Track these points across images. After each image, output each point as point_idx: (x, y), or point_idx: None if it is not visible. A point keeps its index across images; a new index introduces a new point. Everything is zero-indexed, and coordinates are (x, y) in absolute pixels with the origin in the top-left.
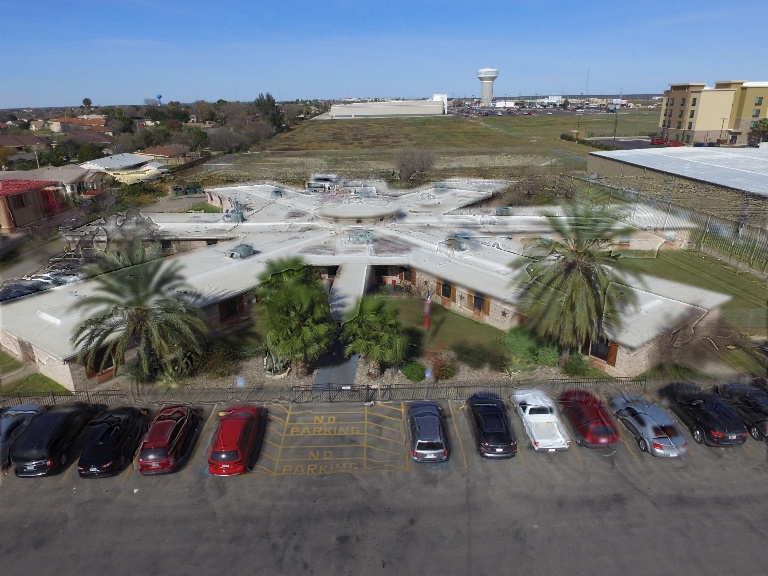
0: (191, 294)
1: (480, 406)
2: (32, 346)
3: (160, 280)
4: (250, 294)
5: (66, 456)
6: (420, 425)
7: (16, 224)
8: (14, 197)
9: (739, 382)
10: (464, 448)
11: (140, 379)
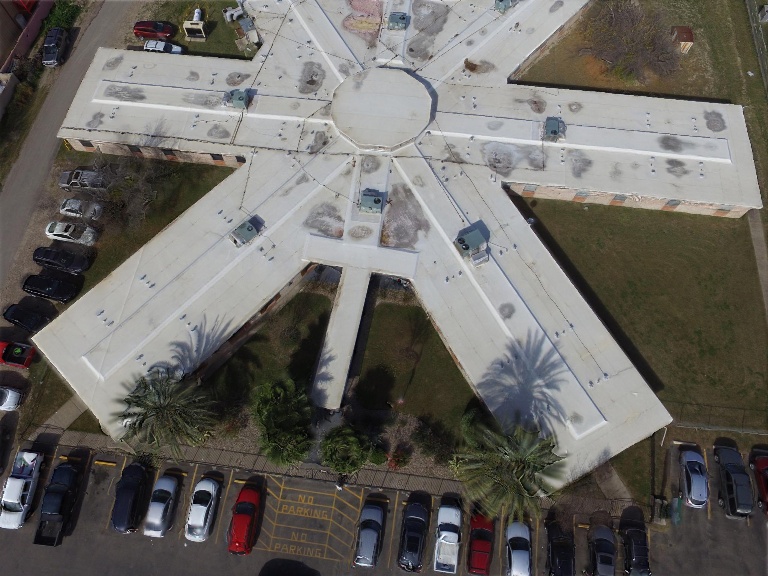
0: (201, 332)
1: (413, 518)
2: None
3: (171, 297)
4: (255, 316)
5: (145, 527)
6: (362, 542)
7: None
8: None
9: (642, 500)
10: (391, 550)
11: (177, 447)
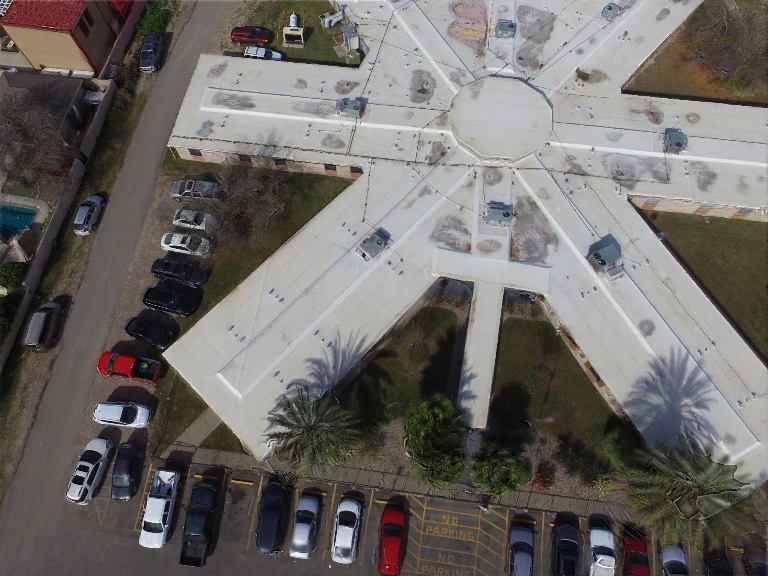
0: (337, 349)
1: (565, 541)
2: (233, 432)
3: (303, 312)
4: None
5: (291, 548)
6: (517, 566)
7: (92, 64)
8: (77, 27)
9: None
10: (543, 574)
11: (317, 466)
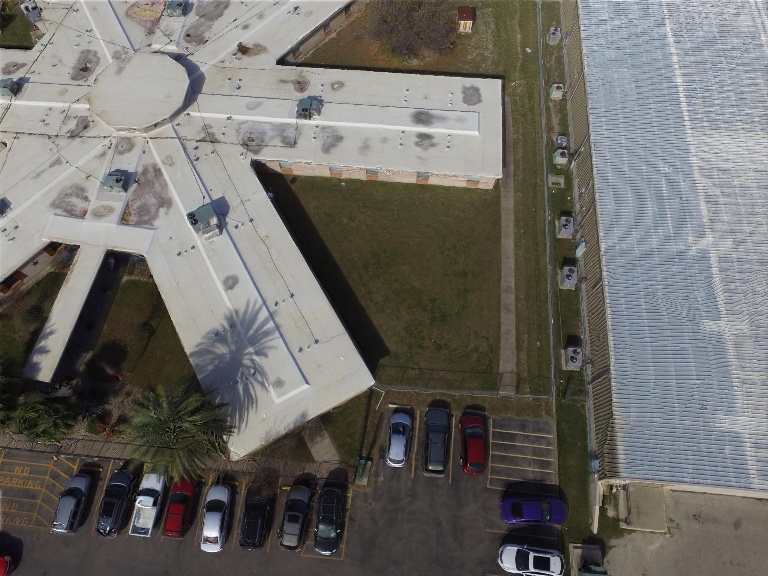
0: None
1: (116, 485)
2: None
3: None
4: None
5: None
6: (60, 508)
7: None
8: None
9: (348, 462)
10: (95, 517)
11: None
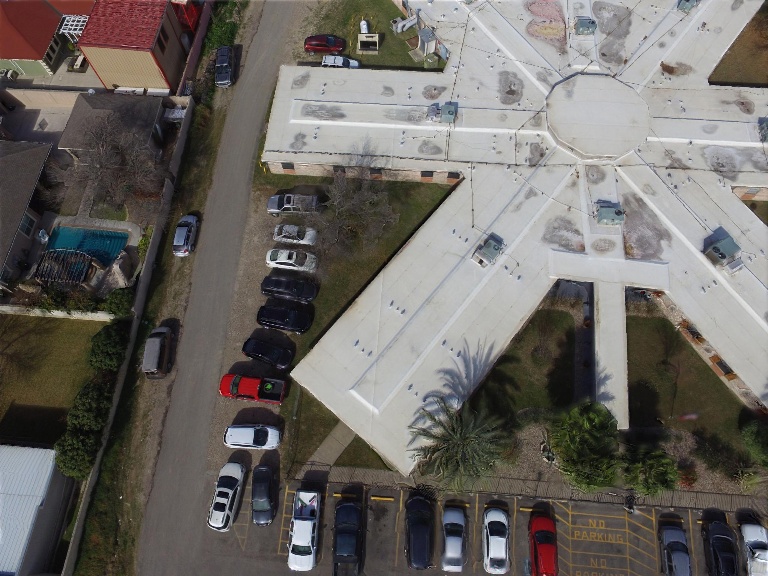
0: (467, 358)
1: (718, 538)
2: (375, 449)
3: (427, 323)
4: None
5: (444, 563)
6: (676, 565)
7: (168, 81)
8: (156, 44)
9: None
10: (698, 571)
11: (459, 478)
